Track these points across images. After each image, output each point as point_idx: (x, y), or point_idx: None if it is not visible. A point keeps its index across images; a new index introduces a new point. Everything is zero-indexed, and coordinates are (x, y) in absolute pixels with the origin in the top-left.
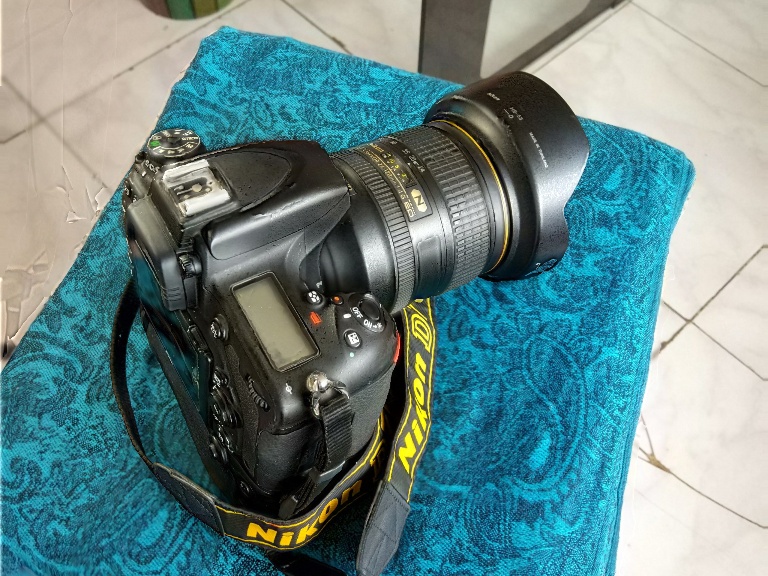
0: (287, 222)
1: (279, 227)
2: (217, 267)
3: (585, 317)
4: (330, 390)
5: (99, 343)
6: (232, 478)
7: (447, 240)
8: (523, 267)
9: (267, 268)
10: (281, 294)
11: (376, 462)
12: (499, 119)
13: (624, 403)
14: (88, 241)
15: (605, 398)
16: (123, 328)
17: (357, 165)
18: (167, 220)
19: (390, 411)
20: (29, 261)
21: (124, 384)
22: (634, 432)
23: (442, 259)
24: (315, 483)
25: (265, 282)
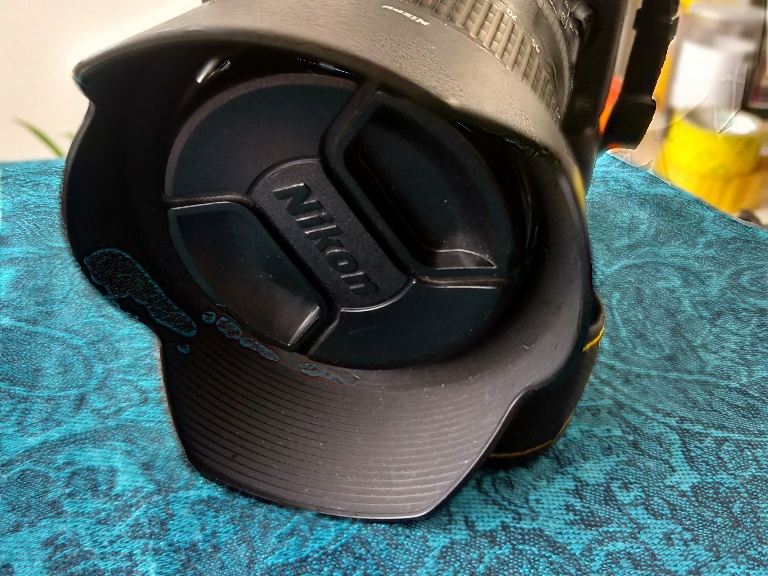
0: None
1: None
2: None
3: None
4: None
5: None
6: None
7: None
8: None
9: None
10: None
11: None
12: None
13: None
14: None
15: None
16: None
17: None
18: None
19: None
20: None
21: None
22: None
23: None
24: None
25: None
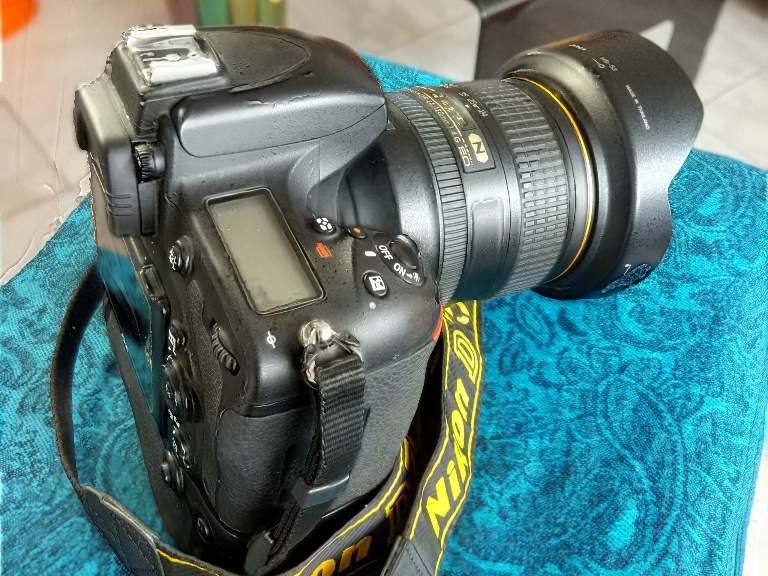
0: (296, 121)
1: (284, 126)
2: (188, 167)
3: (680, 358)
4: (335, 347)
5: (50, 342)
6: (188, 515)
7: (512, 207)
8: (607, 269)
9: (261, 182)
10: (277, 216)
11: (394, 513)
12: (586, 68)
13: (736, 472)
14: (61, 228)
15: (711, 462)
16: (79, 319)
17: (399, 100)
18: (126, 99)
19: (418, 449)
20: (1, 270)
21: (68, 388)
22: (748, 516)
23: (504, 233)
24: (300, 505)
25: (256, 201)
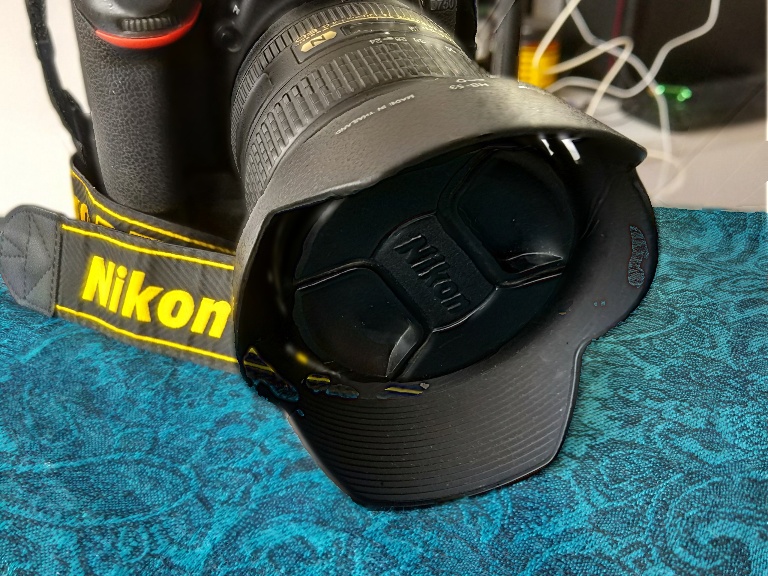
0: None
1: None
2: None
3: (185, 575)
4: None
5: None
6: None
7: None
8: None
9: None
10: None
11: None
12: None
13: None
14: None
15: None
16: None
17: (398, 9)
18: None
19: None
20: None
21: None
22: None
23: None
24: None
25: None
